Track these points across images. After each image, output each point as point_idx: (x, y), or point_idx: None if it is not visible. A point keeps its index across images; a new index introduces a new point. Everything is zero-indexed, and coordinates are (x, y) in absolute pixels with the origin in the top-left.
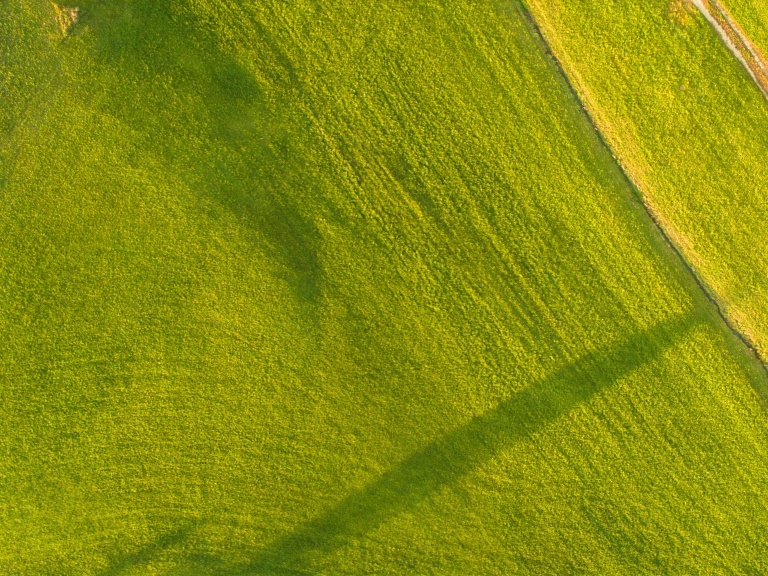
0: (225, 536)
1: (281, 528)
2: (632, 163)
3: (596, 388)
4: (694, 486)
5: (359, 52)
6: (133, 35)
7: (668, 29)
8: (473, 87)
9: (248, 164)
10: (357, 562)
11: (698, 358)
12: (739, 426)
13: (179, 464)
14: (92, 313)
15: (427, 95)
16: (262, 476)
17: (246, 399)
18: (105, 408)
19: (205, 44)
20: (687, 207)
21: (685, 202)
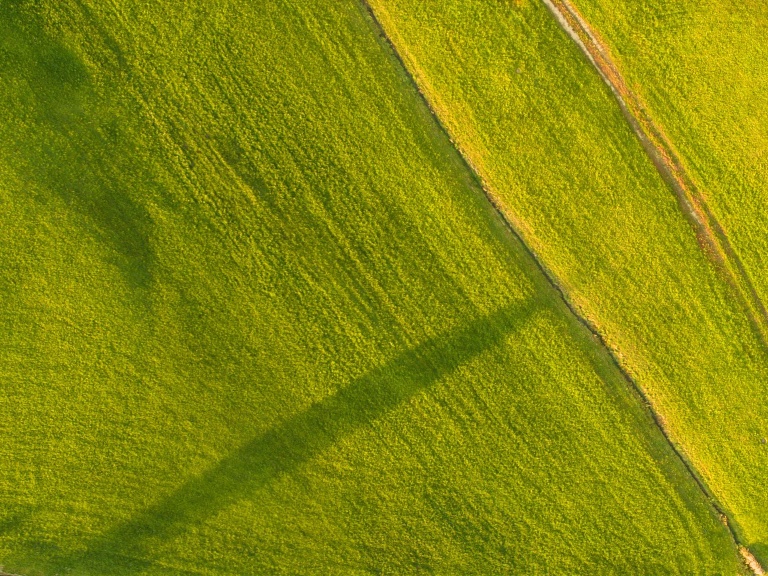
0: (61, 523)
1: (118, 515)
2: (470, 147)
3: (437, 375)
4: (540, 474)
5: (188, 35)
6: None
7: (503, 11)
8: (305, 70)
9: (76, 148)
10: (196, 550)
11: (541, 344)
12: (585, 413)
13: (13, 450)
14: None
15: (258, 78)
16: (97, 463)
17: (79, 385)
18: None
19: (31, 27)
20: (526, 191)
21: (524, 186)
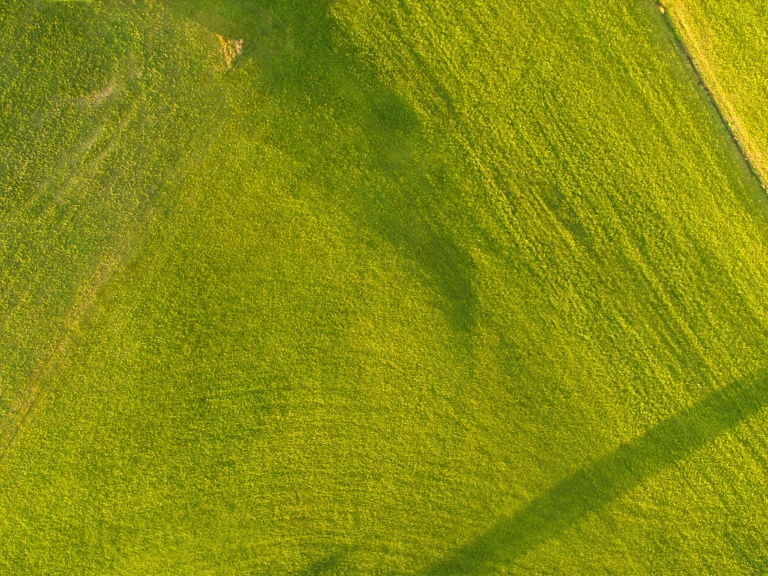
0: (376, 563)
1: (431, 555)
2: None
3: (741, 415)
4: None
5: (515, 83)
6: (295, 67)
7: None
8: (627, 118)
9: (406, 194)
10: None
11: None
12: None
13: (332, 491)
14: (251, 342)
15: (581, 126)
16: (413, 503)
17: (399, 427)
18: (261, 436)
19: (365, 75)
20: None
21: None
